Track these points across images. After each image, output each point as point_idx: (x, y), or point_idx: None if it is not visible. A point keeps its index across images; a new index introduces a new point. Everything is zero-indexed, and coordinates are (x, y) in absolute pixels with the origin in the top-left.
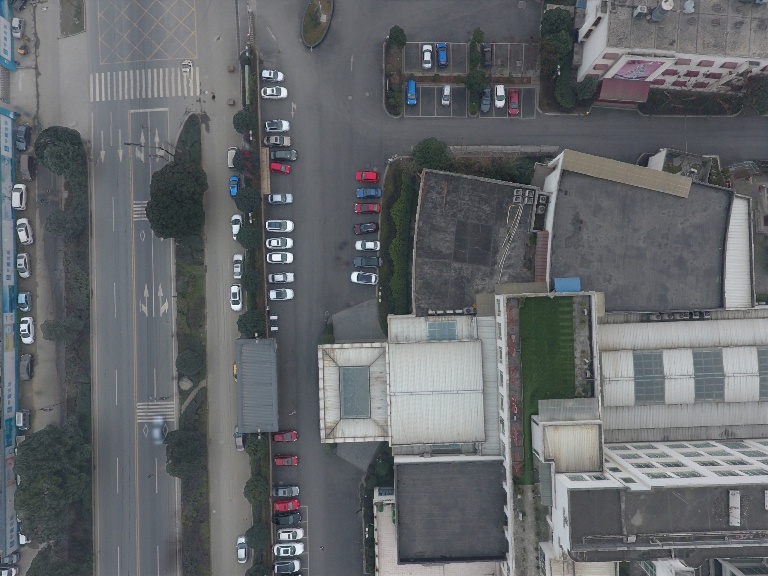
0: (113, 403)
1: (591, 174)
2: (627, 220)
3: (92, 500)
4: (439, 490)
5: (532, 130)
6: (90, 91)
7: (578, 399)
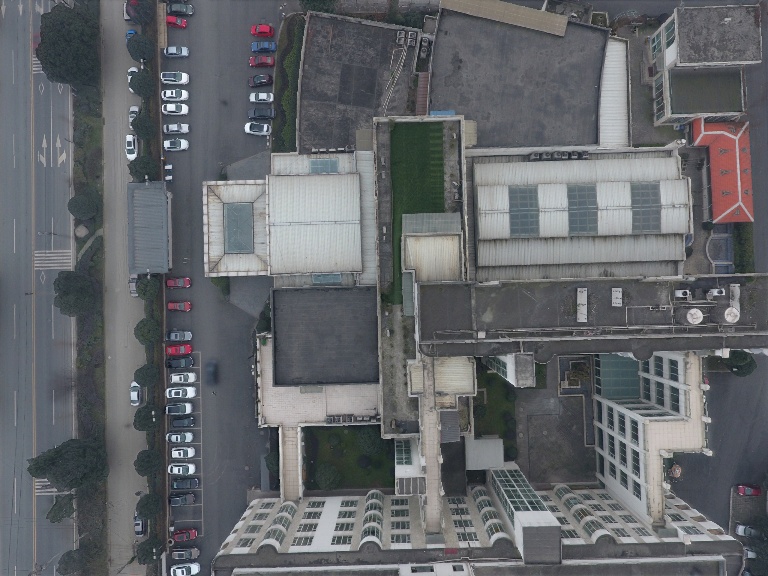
0: (11, 251)
1: (469, 13)
2: (505, 59)
3: None
4: (316, 317)
5: None
6: None
7: (441, 213)
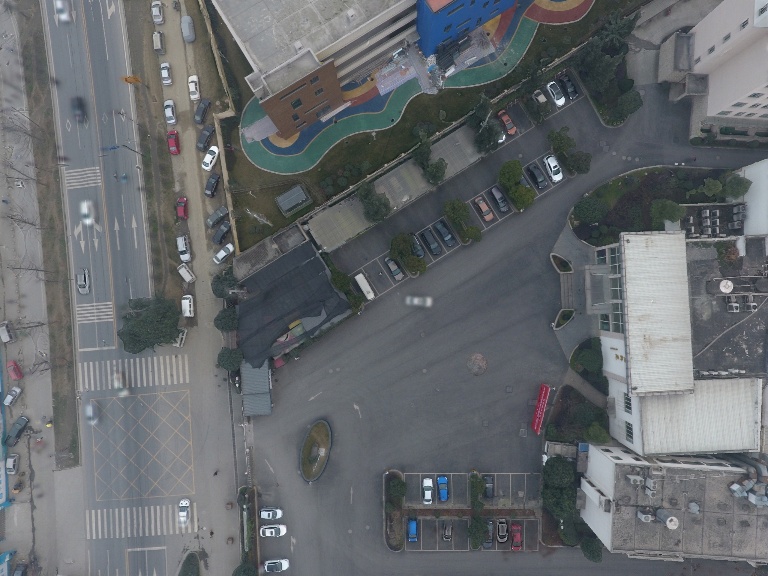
0: None
1: None
2: None
3: None
4: None
5: (535, 563)
6: (86, 528)
7: None
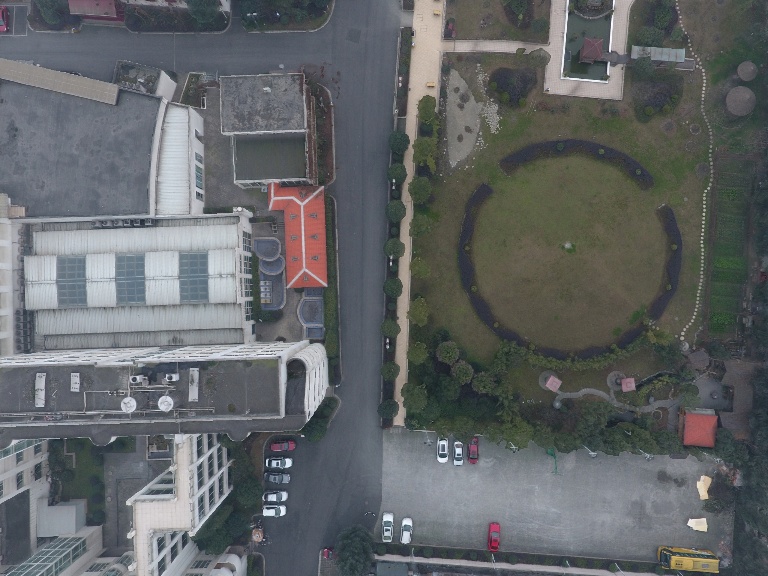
0: None
1: (20, 81)
2: (61, 128)
3: None
4: None
5: (24, 48)
6: None
7: None
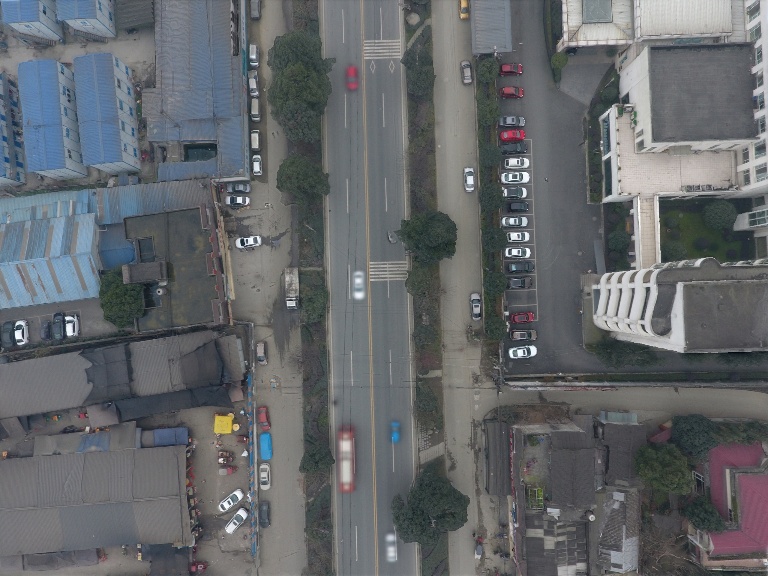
0: (340, 41)
1: None
2: None
3: (321, 134)
4: (688, 77)
5: None
6: None
7: None
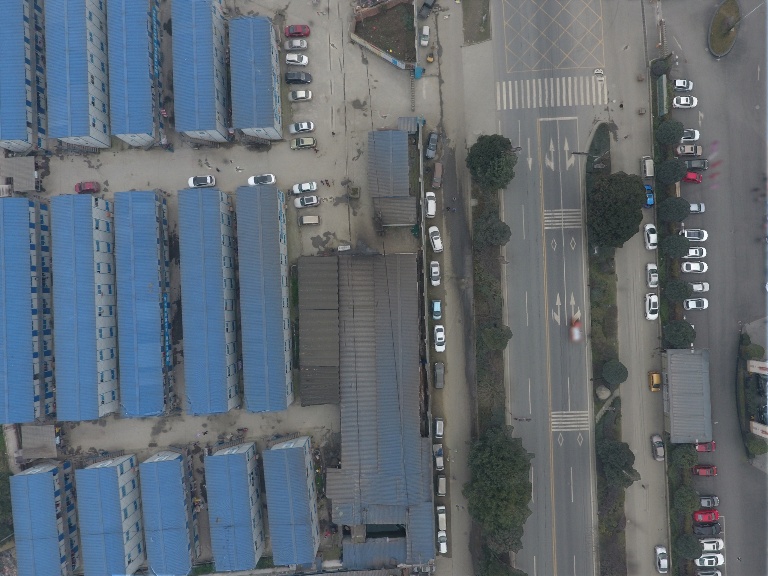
0: (526, 412)
1: None
2: None
3: None
4: None
5: None
6: (497, 99)
7: None
